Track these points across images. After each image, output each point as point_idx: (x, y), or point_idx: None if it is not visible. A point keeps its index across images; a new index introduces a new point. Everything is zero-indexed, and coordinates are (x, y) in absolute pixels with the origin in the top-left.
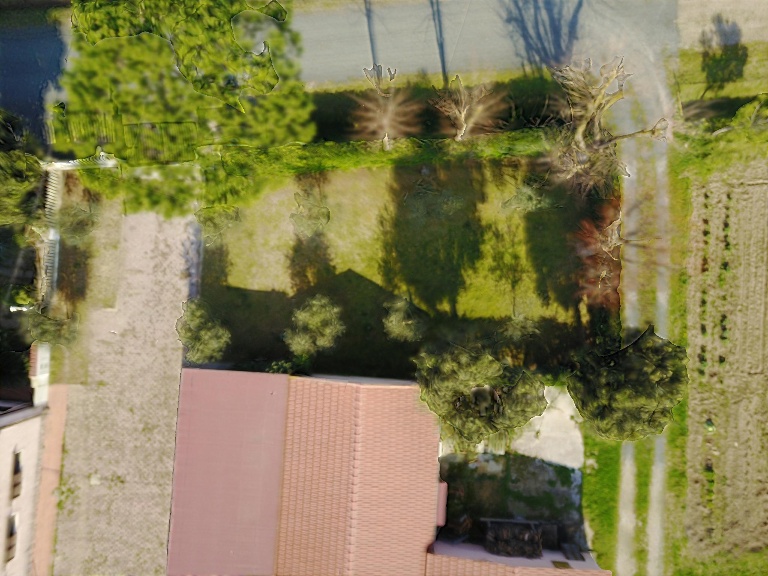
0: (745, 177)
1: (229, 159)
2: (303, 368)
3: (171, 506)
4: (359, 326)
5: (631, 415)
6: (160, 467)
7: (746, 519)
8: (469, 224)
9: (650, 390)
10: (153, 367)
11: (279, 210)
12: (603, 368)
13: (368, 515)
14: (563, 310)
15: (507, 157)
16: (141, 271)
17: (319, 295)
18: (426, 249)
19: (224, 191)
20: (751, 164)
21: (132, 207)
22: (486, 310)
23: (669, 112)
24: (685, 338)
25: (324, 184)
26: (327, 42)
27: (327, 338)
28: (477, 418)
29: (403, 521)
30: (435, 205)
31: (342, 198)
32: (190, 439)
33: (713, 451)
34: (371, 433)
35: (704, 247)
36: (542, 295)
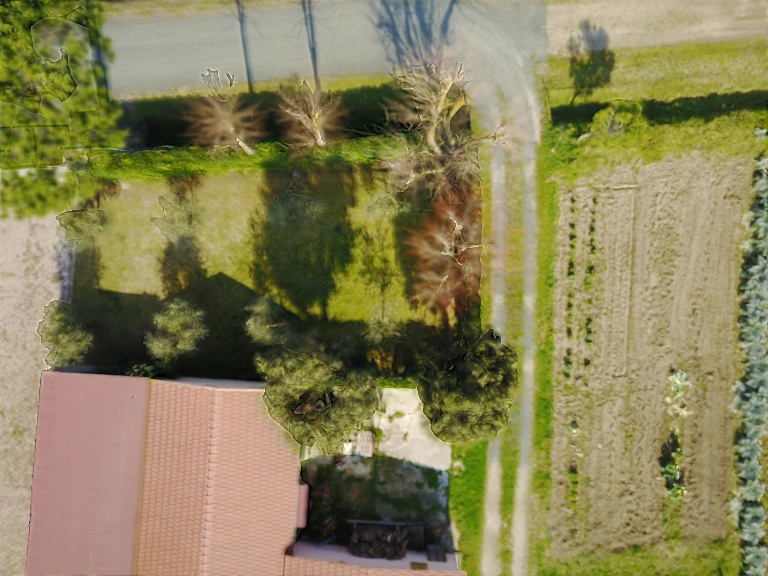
0: (611, 182)
1: (93, 163)
2: (166, 371)
3: (30, 509)
4: (230, 329)
5: (458, 418)
6: (31, 470)
7: (609, 520)
8: (339, 228)
9: (477, 394)
10: (24, 370)
11: (151, 213)
12: (441, 372)
13: (224, 517)
14: (431, 313)
15: (377, 161)
16: (13, 274)
17: (178, 299)
18: (297, 252)
19: (96, 194)
20: (616, 169)
21: (4, 210)
22: (356, 313)
23: (537, 117)
24: (551, 341)
25: (196, 188)
26: (200, 46)
27: (188, 341)
28: (307, 422)
29: (261, 523)
30: (297, 209)
31: (214, 201)
32: (50, 442)
33: (577, 453)
34: (227, 436)
35: (570, 251)
36: (411, 298)
